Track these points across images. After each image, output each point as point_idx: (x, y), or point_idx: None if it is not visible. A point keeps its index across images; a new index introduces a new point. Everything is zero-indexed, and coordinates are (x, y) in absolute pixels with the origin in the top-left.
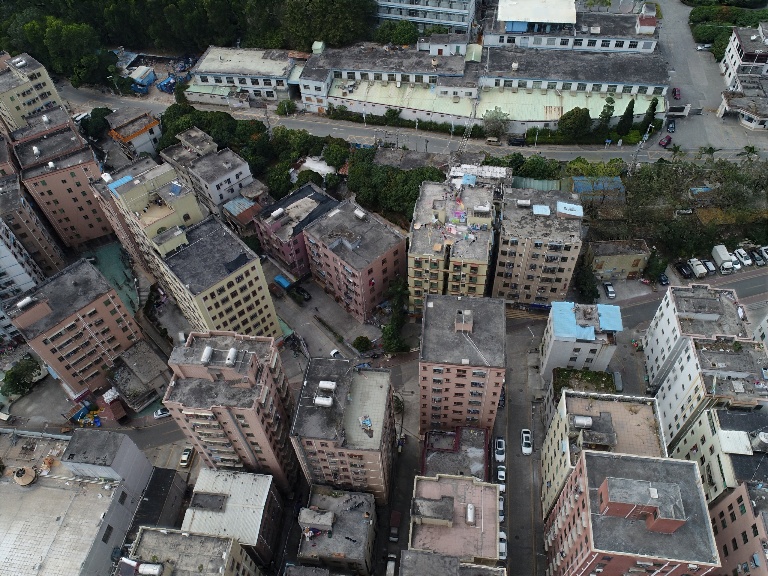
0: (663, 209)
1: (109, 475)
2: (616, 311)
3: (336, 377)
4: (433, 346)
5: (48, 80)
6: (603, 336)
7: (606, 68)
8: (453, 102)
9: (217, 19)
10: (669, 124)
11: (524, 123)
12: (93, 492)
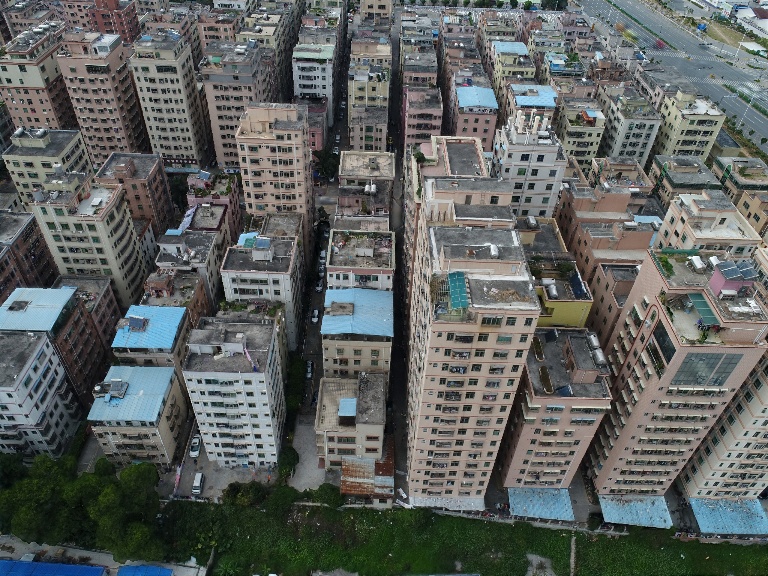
0: None
1: None
2: None
3: (28, 5)
4: (70, 0)
5: None
6: None
7: None
8: None
9: None
10: None
11: None
12: None
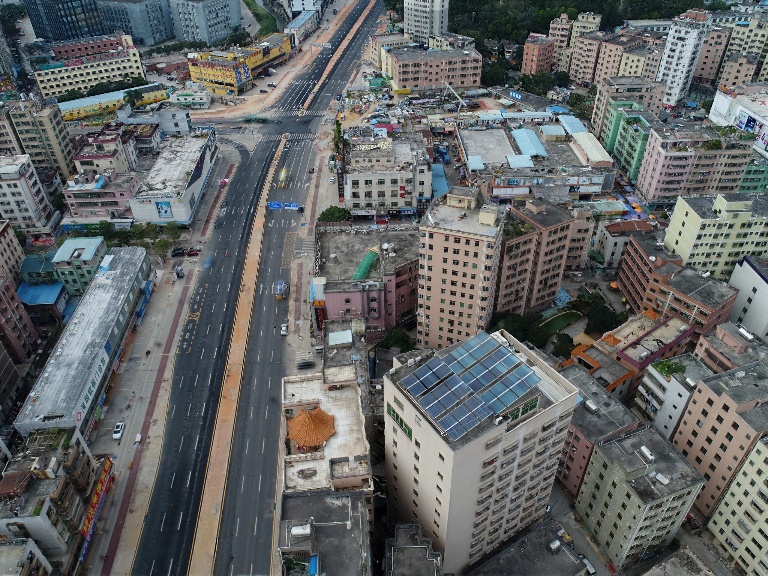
0: None
1: None
2: None
3: None
4: None
5: None
6: None
7: None
8: None
9: (628, 6)
10: None
11: None
12: None
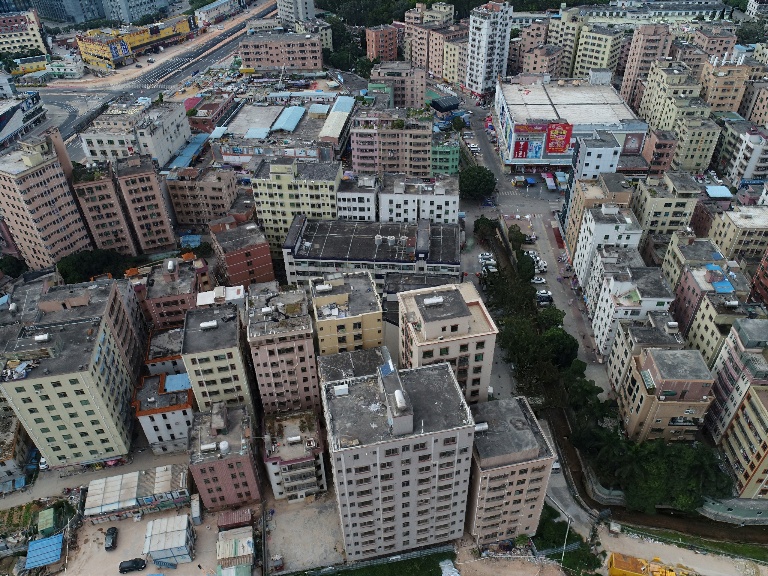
0: None
1: (607, 80)
2: None
3: None
4: None
5: (453, 12)
6: None
7: (702, 7)
8: (638, 20)
9: None
10: None
11: None
12: (601, 86)
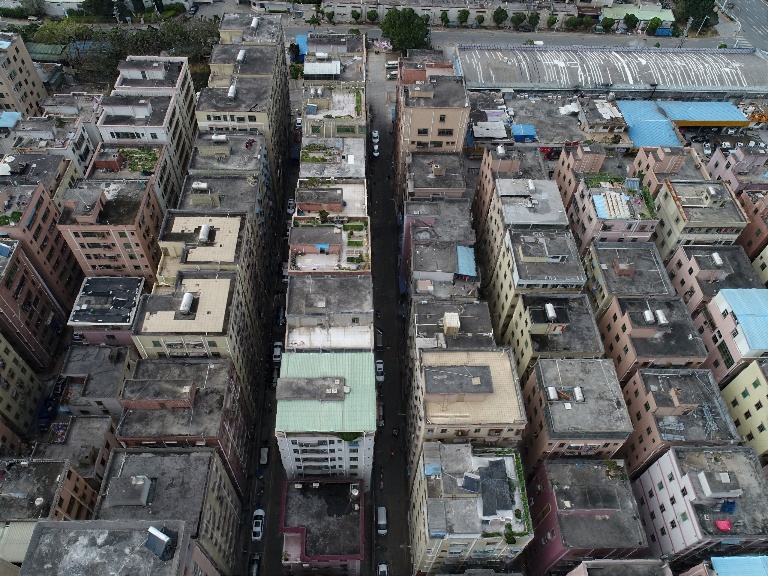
0: (110, 54)
1: None
2: (15, 115)
3: None
4: None
5: None
6: (4, 134)
7: None
8: None
9: None
10: (191, 8)
11: (59, 4)
12: None
